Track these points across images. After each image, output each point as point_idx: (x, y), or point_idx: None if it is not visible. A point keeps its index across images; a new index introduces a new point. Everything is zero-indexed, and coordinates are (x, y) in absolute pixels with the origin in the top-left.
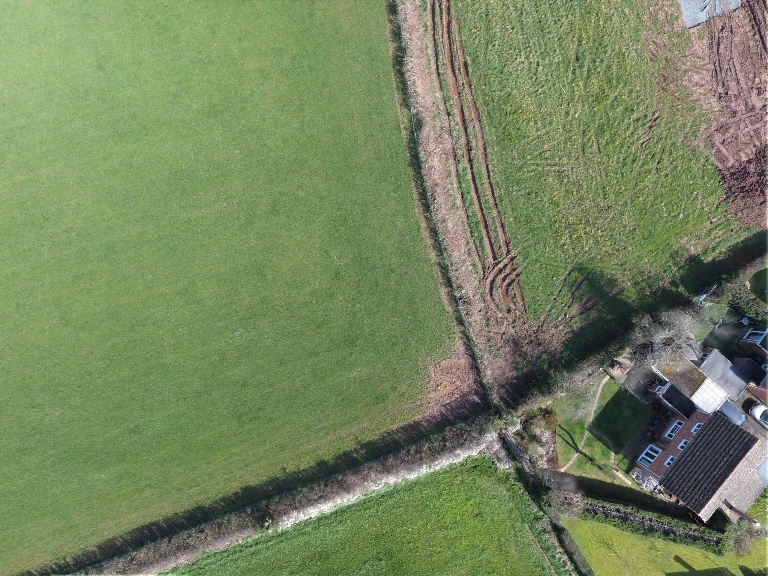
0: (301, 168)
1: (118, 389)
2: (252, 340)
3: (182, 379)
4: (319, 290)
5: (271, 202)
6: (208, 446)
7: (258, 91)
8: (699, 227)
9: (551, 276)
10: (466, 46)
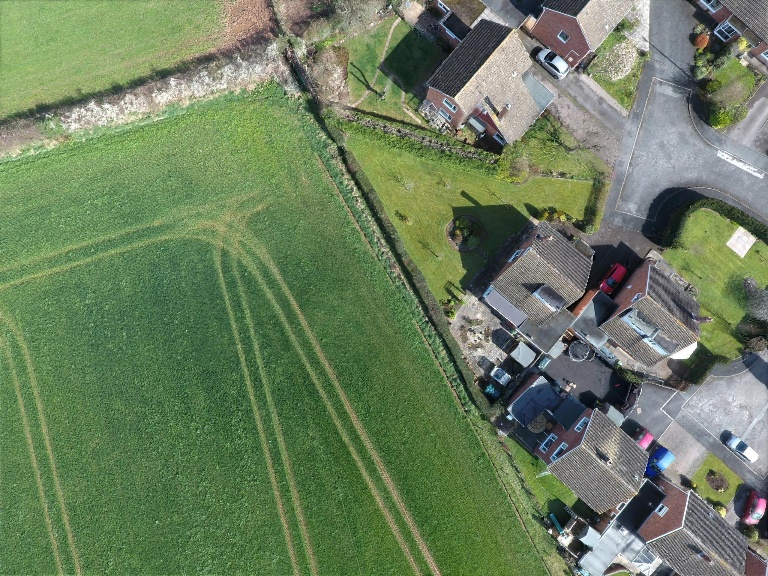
0: None
1: None
2: None
3: None
4: None
5: None
6: (4, 63)
7: None
8: None
9: None
10: None
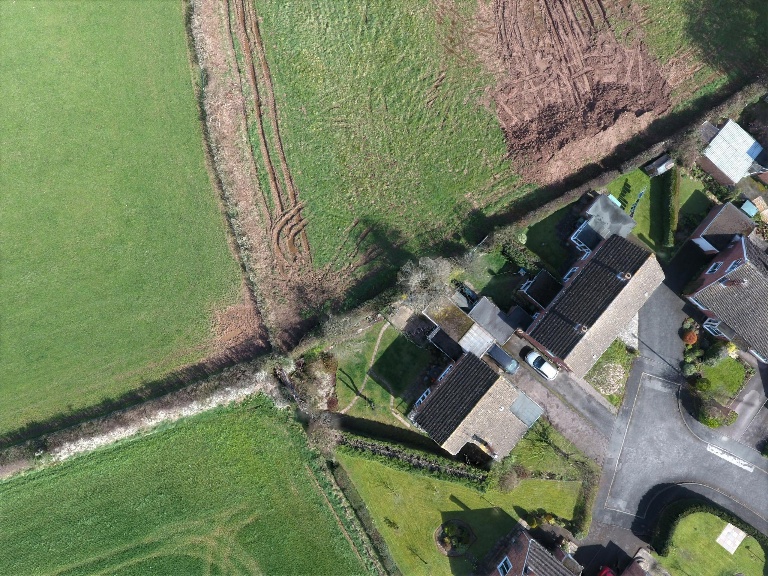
0: (95, 120)
1: None
2: (42, 283)
3: None
4: (109, 237)
5: (65, 152)
6: None
7: (55, 47)
8: (483, 183)
9: (337, 227)
10: (258, 7)
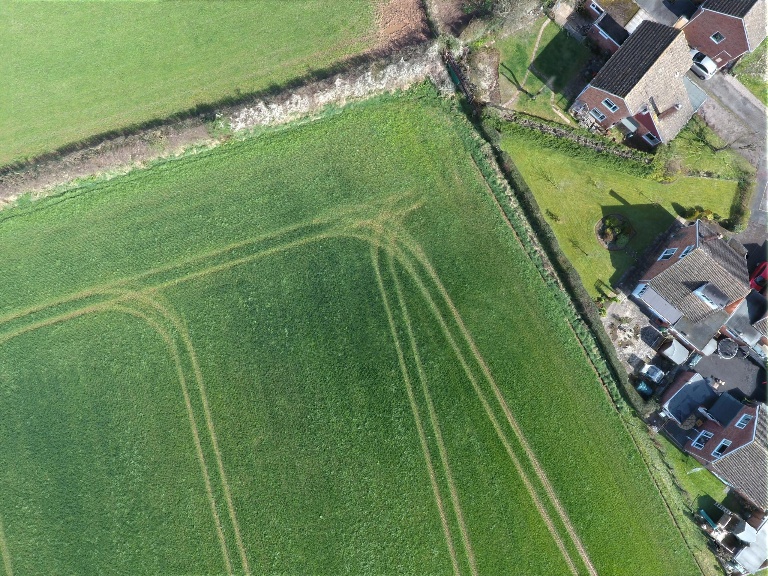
0: None
1: (80, 6)
2: None
3: (142, 1)
4: None
5: None
6: (166, 63)
7: None
8: None
9: None
10: None
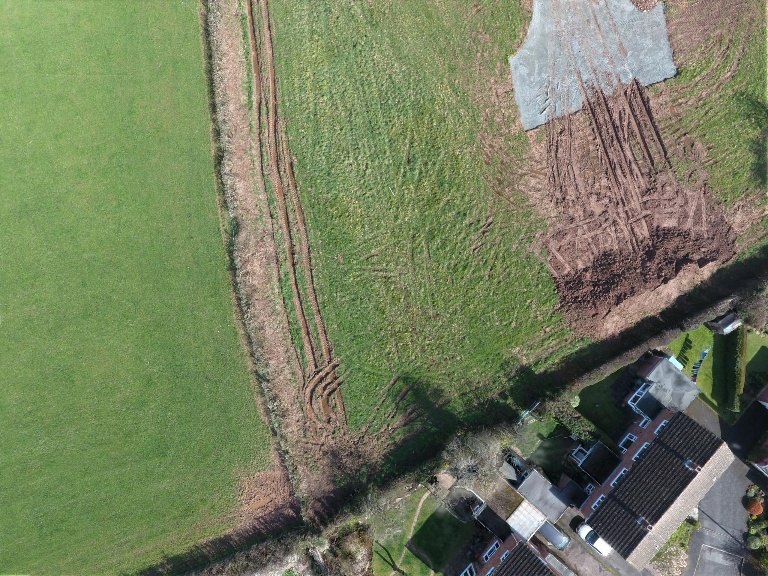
0: (116, 270)
1: None
2: (57, 449)
3: None
4: (130, 397)
5: (83, 305)
6: (5, 559)
7: (73, 190)
8: (532, 336)
9: (374, 385)
10: (292, 146)
